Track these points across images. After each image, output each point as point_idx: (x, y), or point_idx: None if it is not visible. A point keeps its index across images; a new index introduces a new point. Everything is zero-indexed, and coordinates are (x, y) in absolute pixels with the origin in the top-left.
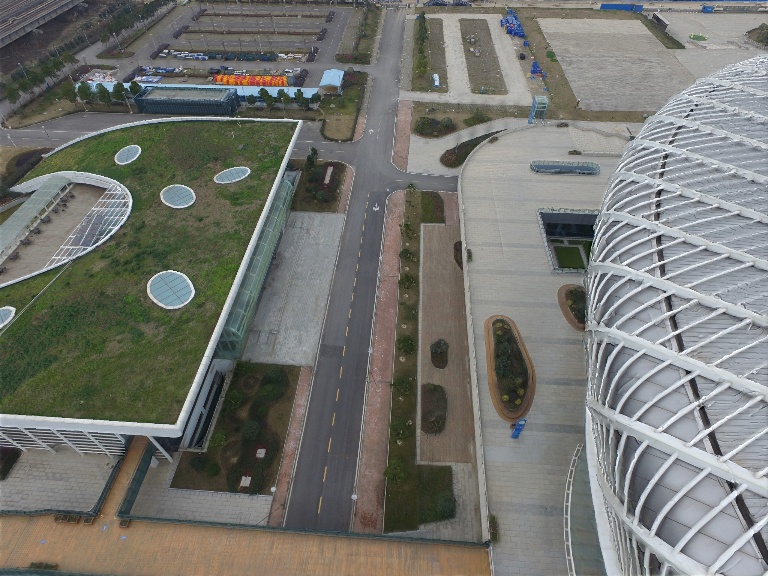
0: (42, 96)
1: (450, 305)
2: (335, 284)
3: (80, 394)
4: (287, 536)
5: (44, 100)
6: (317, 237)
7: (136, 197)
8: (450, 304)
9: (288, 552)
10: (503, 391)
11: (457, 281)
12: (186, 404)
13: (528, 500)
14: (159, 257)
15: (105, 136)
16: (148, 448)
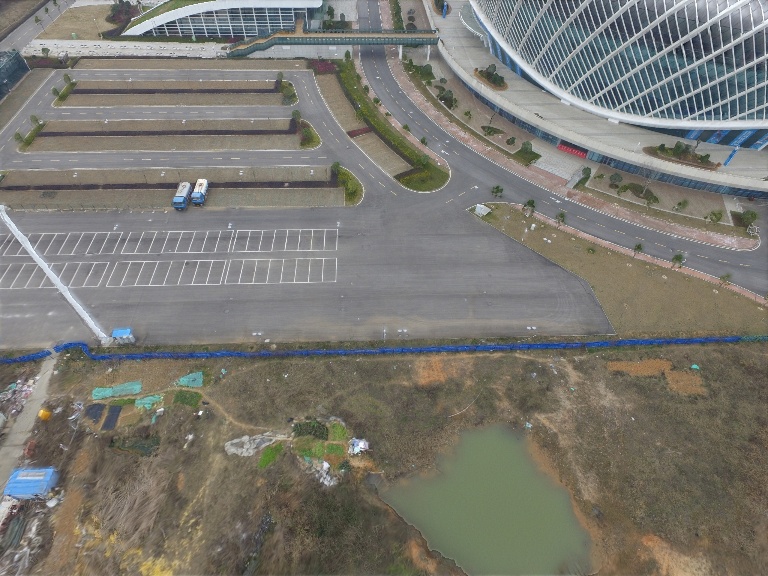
0: None
1: (414, 8)
2: (358, 3)
3: None
4: None
5: None
6: None
7: None
8: (414, 8)
9: None
10: (439, 8)
11: (416, 2)
12: None
13: (449, 27)
14: None
15: None
16: None
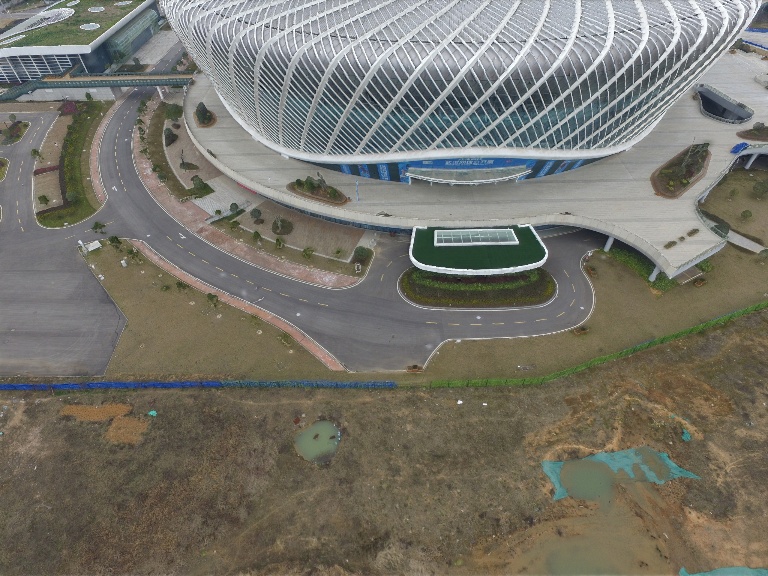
0: (24, 3)
1: None
2: None
3: (54, 44)
4: (129, 76)
5: (25, 4)
6: (170, 37)
7: (77, 11)
8: None
9: (128, 78)
10: None
11: None
12: (93, 42)
13: None
14: (86, 21)
15: None
16: None
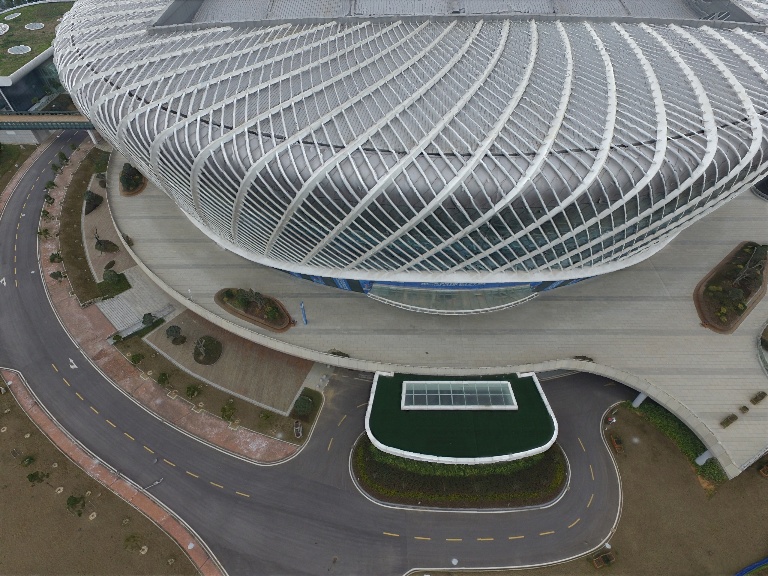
0: None
1: None
2: None
3: None
4: (55, 116)
5: None
6: None
7: (12, 27)
8: None
9: None
10: None
11: None
12: (15, 72)
13: None
14: (17, 43)
15: (3, 14)
16: (1, 100)
